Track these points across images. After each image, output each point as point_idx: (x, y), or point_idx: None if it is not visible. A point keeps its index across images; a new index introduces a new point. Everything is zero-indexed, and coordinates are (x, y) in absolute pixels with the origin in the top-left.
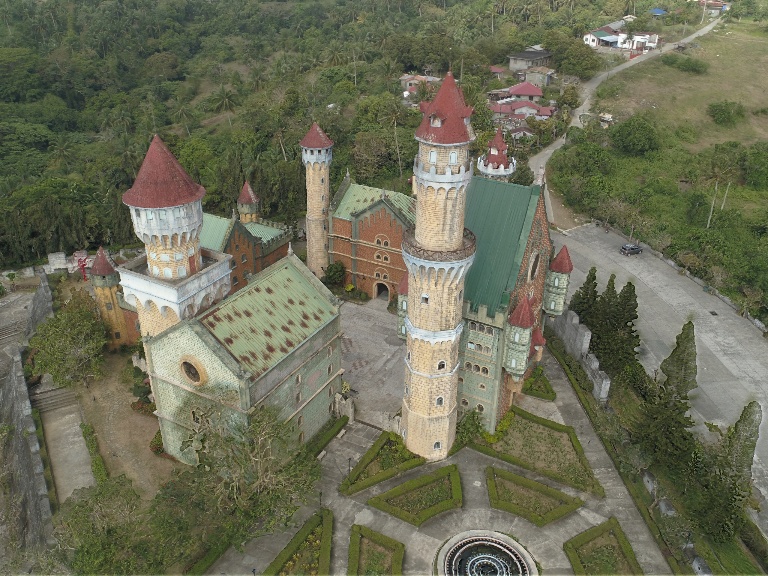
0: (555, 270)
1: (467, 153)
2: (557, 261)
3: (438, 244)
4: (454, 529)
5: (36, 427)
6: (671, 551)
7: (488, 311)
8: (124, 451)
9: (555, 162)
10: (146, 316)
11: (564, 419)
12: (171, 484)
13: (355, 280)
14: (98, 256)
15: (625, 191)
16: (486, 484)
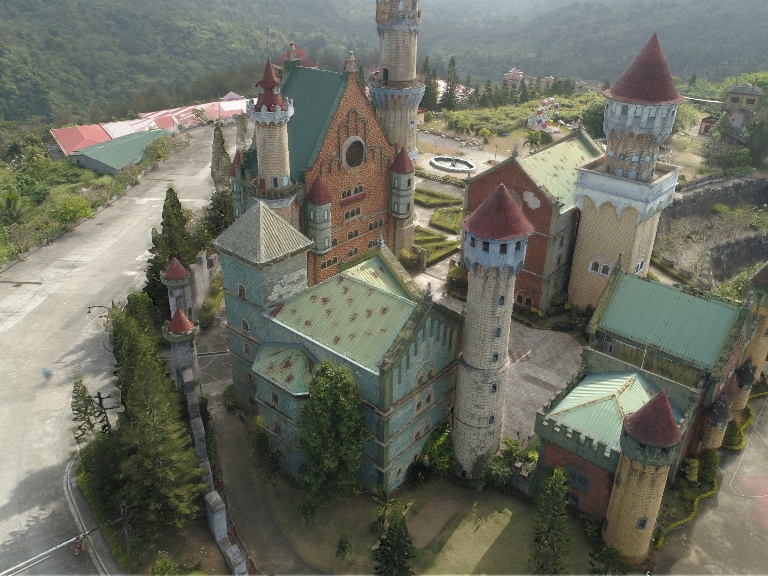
0: None
1: None
2: None
3: None
4: None
5: None
6: None
7: None
8: None
9: None
10: None
11: None
12: None
13: None
14: None
15: None
16: None
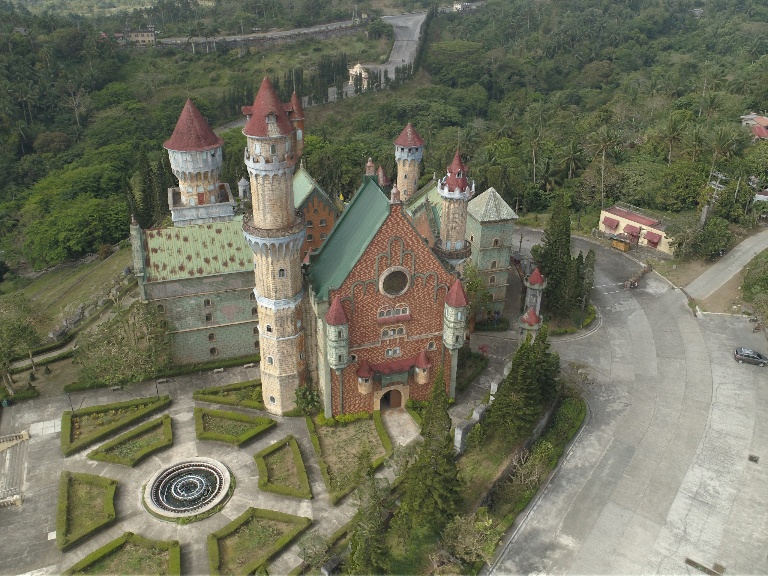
0: (445, 300)
1: (274, 148)
2: (449, 292)
3: (258, 220)
4: (215, 455)
5: (130, 282)
6: (313, 567)
7: None
8: None
9: None
10: None
11: (408, 444)
12: None
13: None
14: None
15: None
16: None
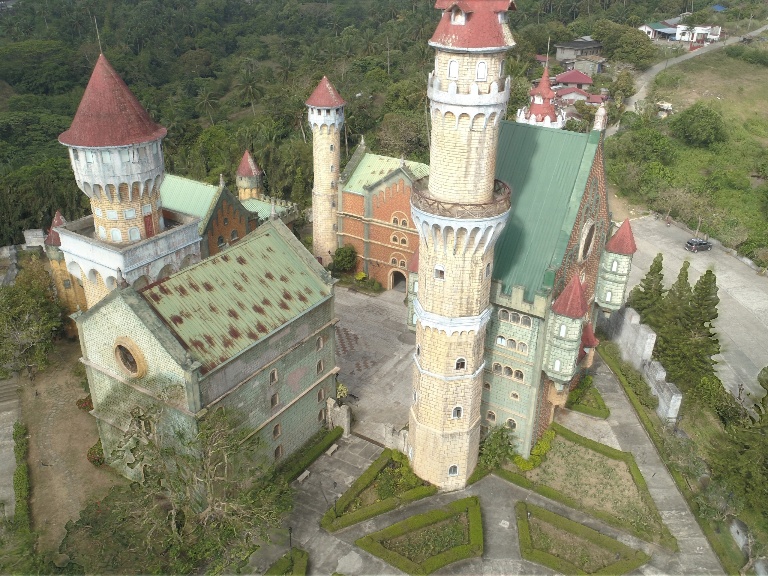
0: (613, 250)
1: (501, 66)
2: (616, 239)
3: (458, 195)
4: None
5: None
6: None
7: (525, 295)
8: (57, 459)
9: (607, 148)
10: (93, 291)
11: (620, 443)
12: (94, 507)
13: (367, 267)
14: (54, 222)
15: (689, 182)
16: (516, 525)
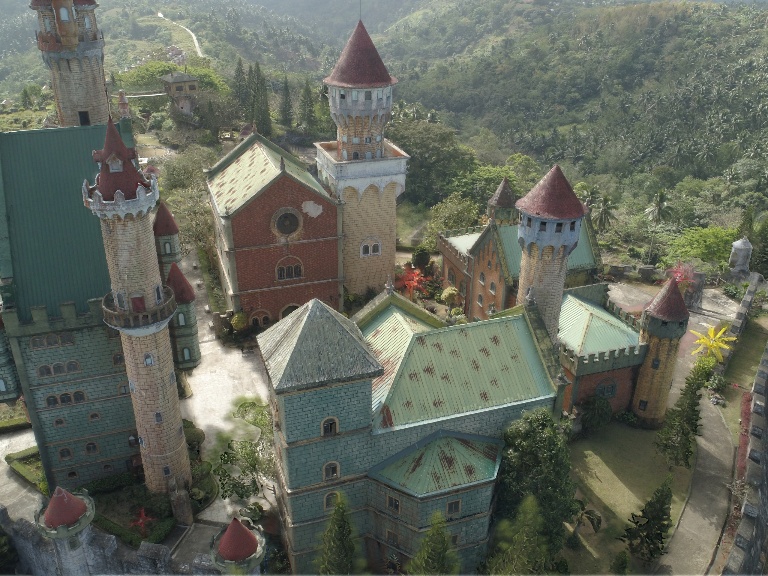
0: None
1: None
2: None
3: None
4: None
5: (414, 244)
6: None
7: None
8: None
9: None
10: None
11: None
12: None
13: None
14: None
15: None
16: None
